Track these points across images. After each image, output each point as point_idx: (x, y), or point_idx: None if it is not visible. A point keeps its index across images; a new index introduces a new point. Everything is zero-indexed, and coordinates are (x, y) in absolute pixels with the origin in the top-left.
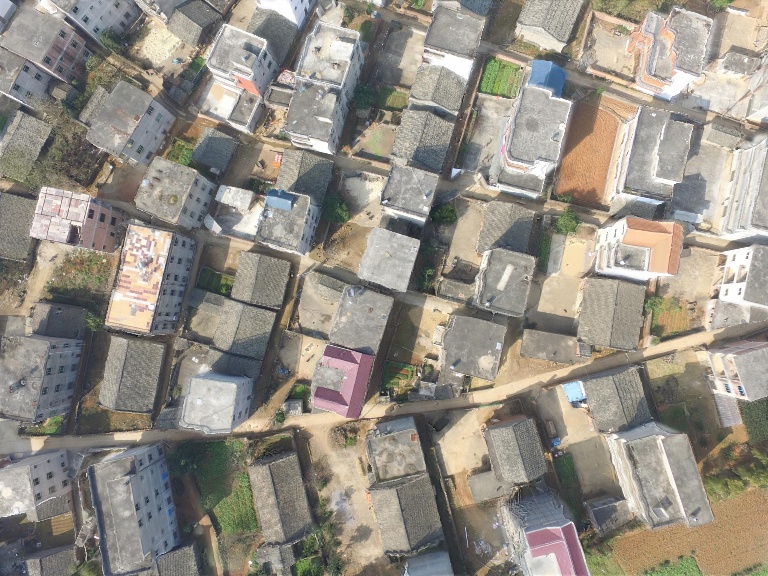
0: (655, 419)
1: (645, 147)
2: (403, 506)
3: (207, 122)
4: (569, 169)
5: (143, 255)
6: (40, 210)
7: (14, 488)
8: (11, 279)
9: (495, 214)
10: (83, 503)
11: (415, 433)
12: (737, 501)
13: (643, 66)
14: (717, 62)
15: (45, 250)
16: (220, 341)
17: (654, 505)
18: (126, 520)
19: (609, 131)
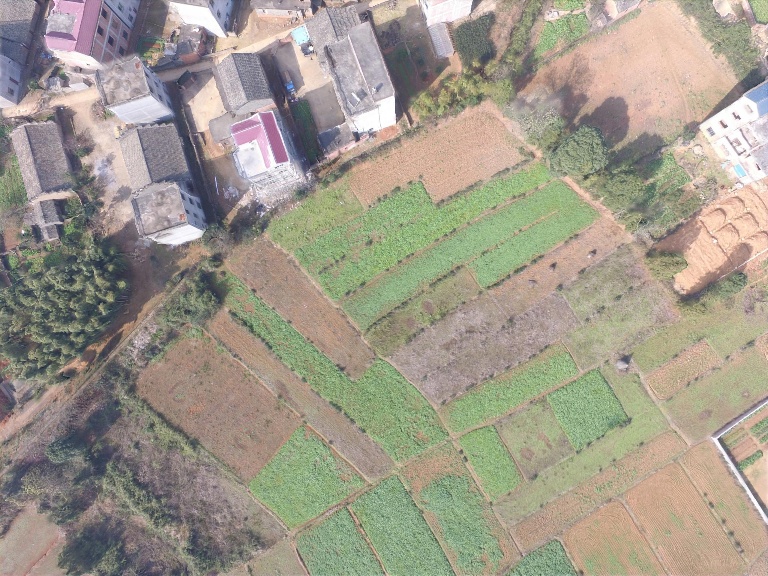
0: None
1: None
2: (145, 146)
3: None
4: None
5: None
6: None
7: None
8: None
9: None
10: None
11: (139, 61)
12: (457, 126)
13: None
14: None
15: None
16: None
17: (351, 97)
18: None
19: None
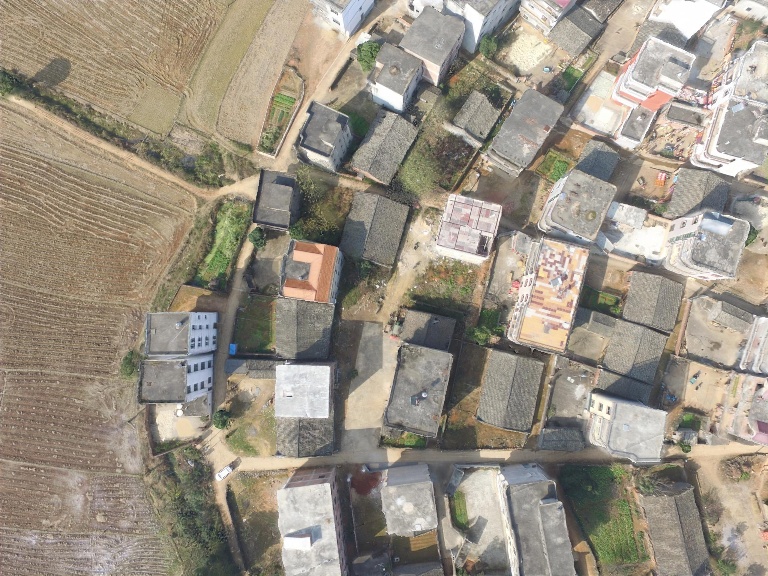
0: None
1: None
2: None
3: (581, 134)
4: None
5: (557, 271)
6: (449, 218)
7: (416, 504)
8: (371, 284)
9: None
10: (452, 520)
11: None
12: None
13: None
14: None
15: (407, 256)
16: (614, 363)
17: None
18: (559, 547)
19: None
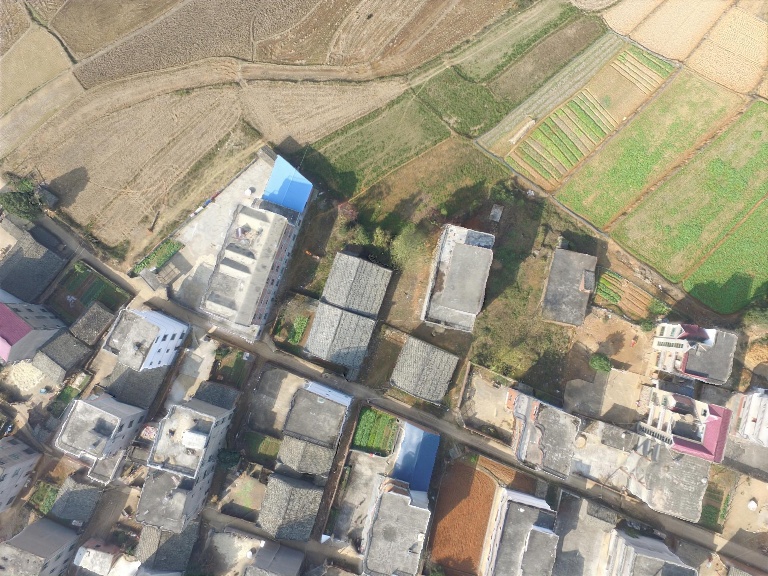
0: None
1: (512, 546)
2: None
3: None
4: (444, 534)
5: None
6: None
7: None
8: None
9: None
10: None
11: None
12: None
13: (517, 439)
14: (598, 424)
15: None
16: None
17: None
18: None
19: (486, 494)
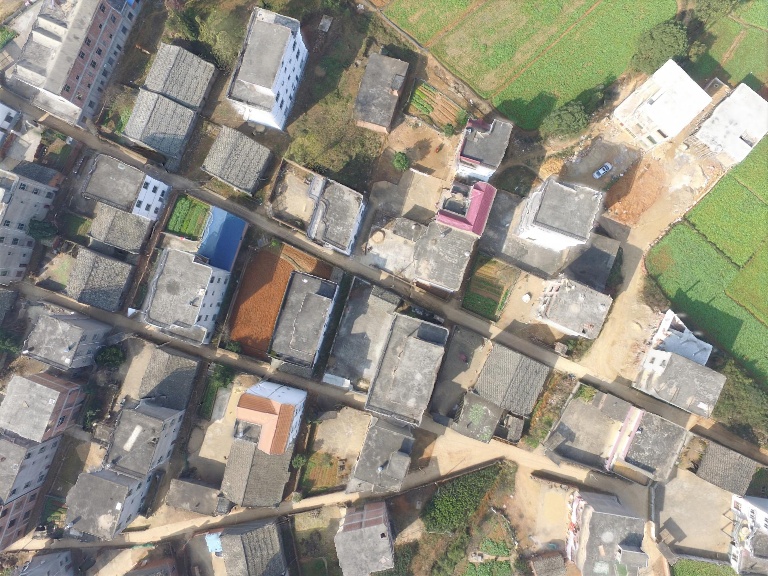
0: (296, 570)
1: (294, 312)
2: None
3: None
4: (246, 316)
5: None
6: None
7: None
8: None
9: (156, 362)
10: None
11: None
12: None
13: None
14: None
15: None
16: None
17: None
18: None
19: None
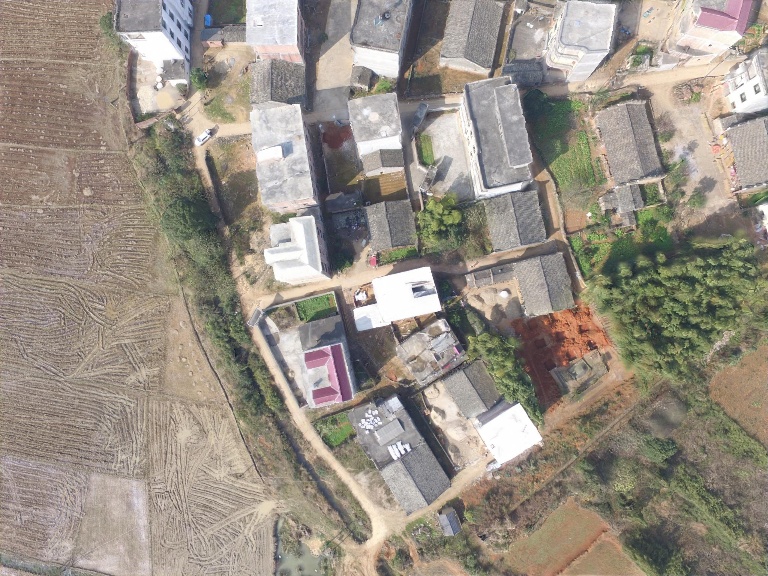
0: None
1: None
2: None
3: None
4: None
5: None
6: None
7: (381, 113)
8: None
9: None
10: (418, 159)
11: None
12: None
13: None
14: None
15: None
16: None
17: None
18: (514, 124)
19: None
